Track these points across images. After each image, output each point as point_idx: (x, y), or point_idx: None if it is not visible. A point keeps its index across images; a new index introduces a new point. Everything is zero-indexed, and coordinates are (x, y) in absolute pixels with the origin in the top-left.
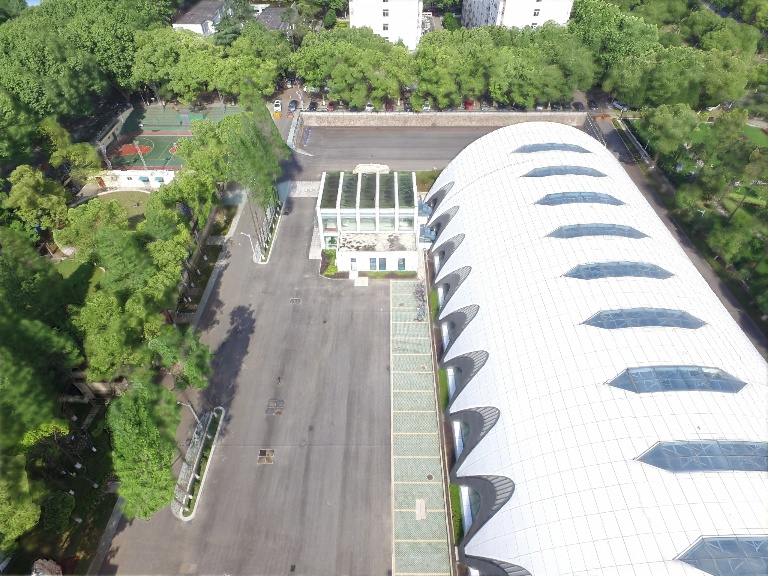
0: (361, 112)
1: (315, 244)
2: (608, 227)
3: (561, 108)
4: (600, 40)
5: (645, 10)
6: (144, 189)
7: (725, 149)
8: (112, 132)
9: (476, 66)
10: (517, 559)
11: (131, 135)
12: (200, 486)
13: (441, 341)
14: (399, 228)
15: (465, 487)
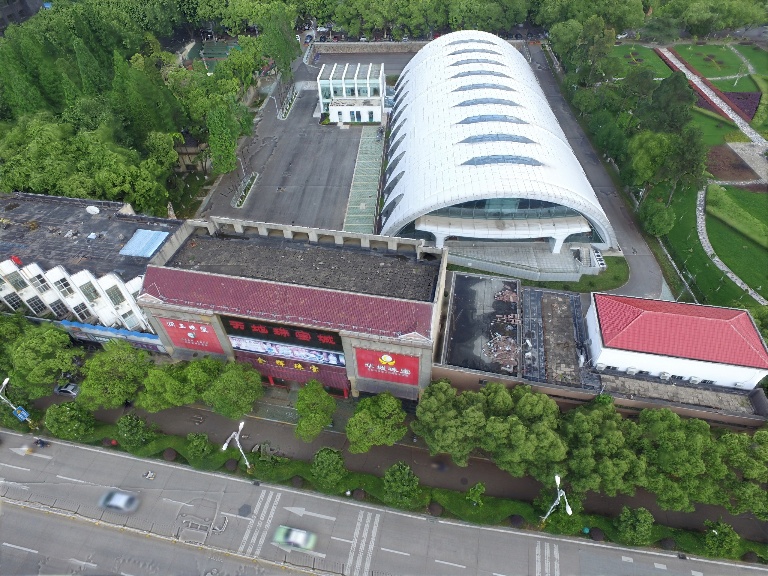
0: (357, 42)
1: (317, 111)
2: None
3: (505, 38)
4: None
5: None
6: None
7: None
8: (182, 56)
9: (439, 5)
10: (399, 193)
11: None
12: (246, 197)
13: None
14: (371, 96)
15: (387, 194)
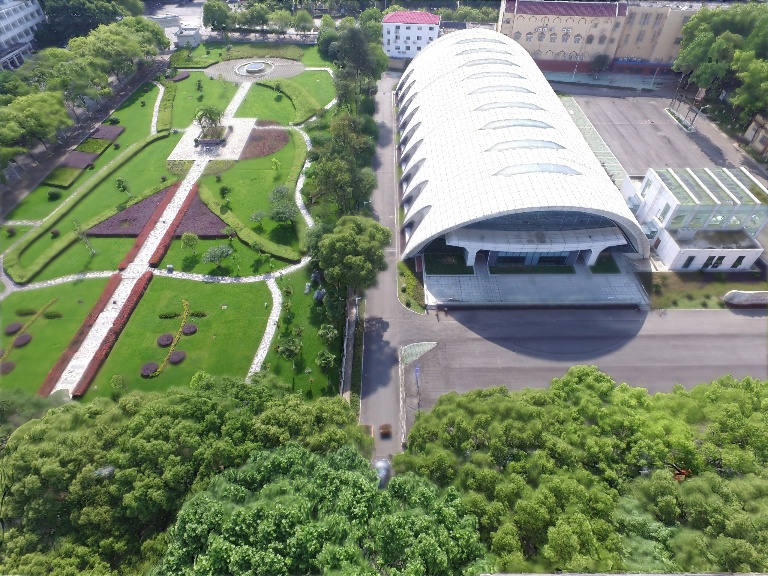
0: None
1: None
2: None
3: None
4: None
5: None
6: None
7: (209, 341)
8: None
9: None
10: None
11: None
12: None
13: None
14: None
15: None
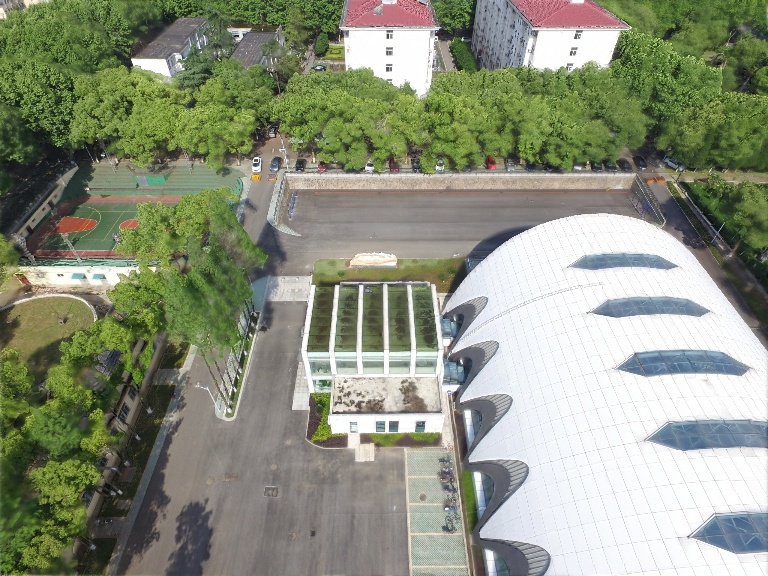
0: (359, 173)
1: (301, 384)
2: (740, 424)
3: (603, 167)
4: (652, 86)
5: (686, 38)
6: (80, 287)
7: None
8: (48, 202)
9: (502, 120)
10: None
11: (74, 202)
12: None
13: (484, 574)
14: (415, 369)
15: None
